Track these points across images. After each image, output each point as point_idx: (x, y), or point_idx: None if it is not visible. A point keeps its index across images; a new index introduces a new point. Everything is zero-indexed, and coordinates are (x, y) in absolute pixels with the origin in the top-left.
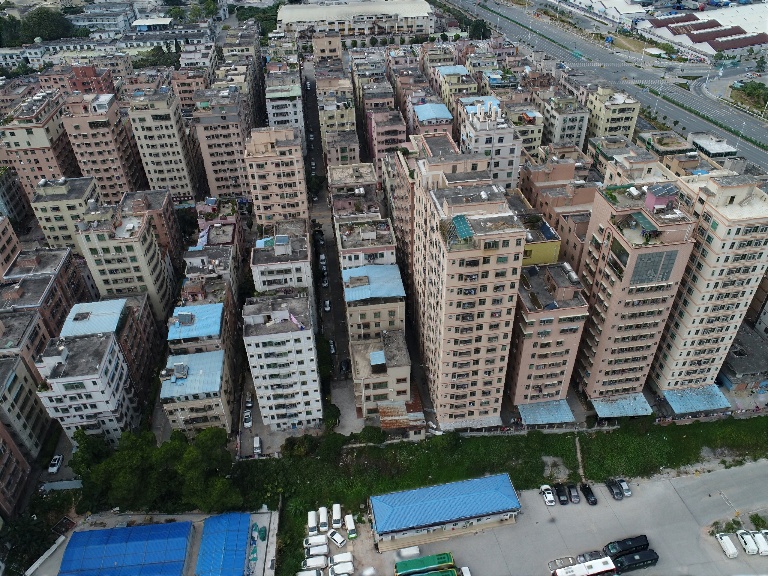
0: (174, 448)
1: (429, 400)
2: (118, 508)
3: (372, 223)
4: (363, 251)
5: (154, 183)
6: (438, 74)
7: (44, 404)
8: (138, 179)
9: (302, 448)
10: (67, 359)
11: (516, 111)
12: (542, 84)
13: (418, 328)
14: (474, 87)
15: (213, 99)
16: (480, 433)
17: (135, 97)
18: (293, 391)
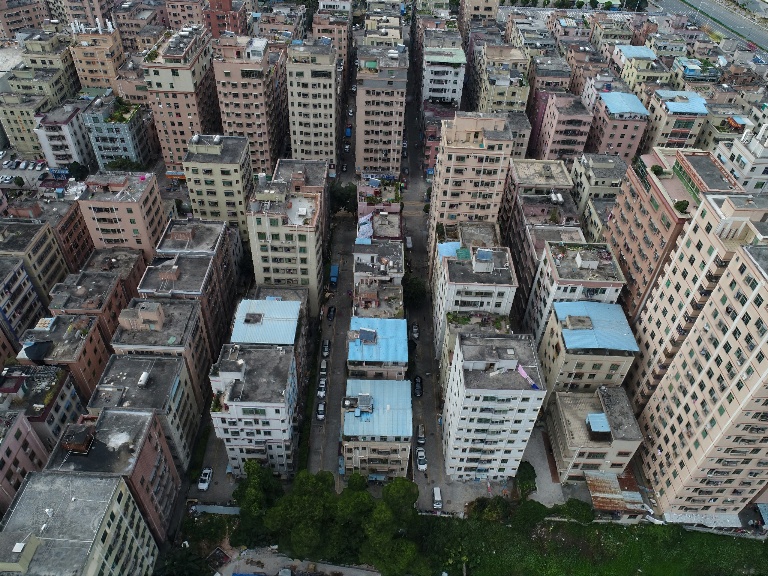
0: (362, 502)
1: (637, 472)
2: (277, 546)
3: (588, 247)
4: (584, 284)
5: (297, 145)
6: (619, 54)
7: None
8: (275, 137)
9: (494, 513)
10: (245, 375)
11: (721, 114)
12: (745, 82)
13: (631, 383)
14: (666, 77)
15: (380, 59)
16: (707, 529)
17: (293, 46)
18: (495, 447)
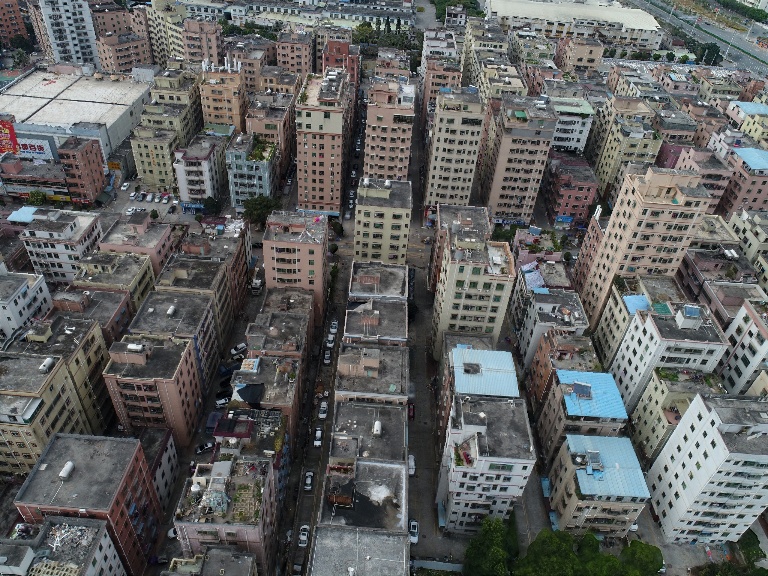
0: (613, 567)
1: None
2: None
3: None
4: None
5: (433, 189)
6: (736, 110)
7: (453, 478)
8: None
9: None
10: None
11: None
12: None
13: None
14: None
15: (528, 109)
16: None
17: (443, 94)
18: (730, 512)
